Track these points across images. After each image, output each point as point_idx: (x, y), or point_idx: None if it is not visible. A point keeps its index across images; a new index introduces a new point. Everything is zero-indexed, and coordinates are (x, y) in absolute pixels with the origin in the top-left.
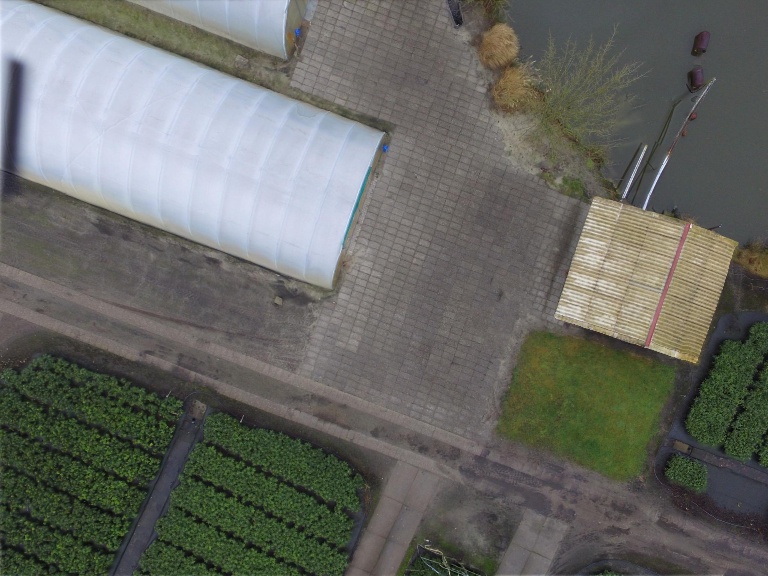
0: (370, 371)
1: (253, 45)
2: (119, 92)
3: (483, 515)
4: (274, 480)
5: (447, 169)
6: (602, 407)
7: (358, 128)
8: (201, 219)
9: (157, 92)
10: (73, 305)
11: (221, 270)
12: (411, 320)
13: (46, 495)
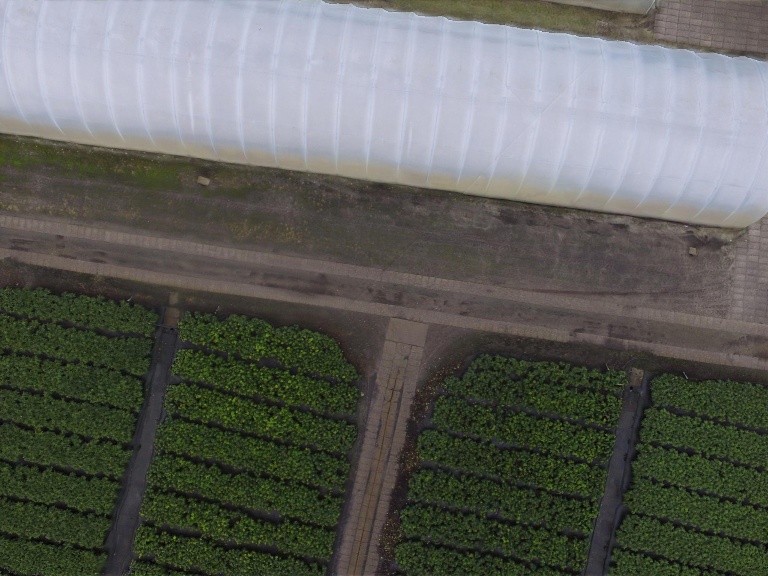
0: None
1: (613, 7)
2: (545, 72)
3: None
4: (733, 428)
5: None
6: None
7: None
8: (632, 182)
9: (579, 64)
10: (494, 301)
11: (629, 234)
12: None
13: (514, 493)
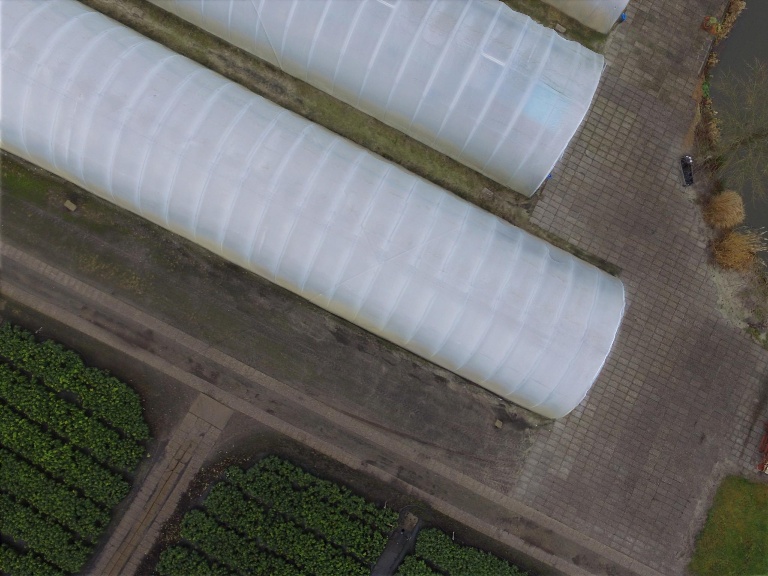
0: (577, 500)
1: (502, 181)
2: (401, 226)
3: None
4: None
5: (664, 315)
6: None
7: (602, 276)
8: (453, 348)
9: (435, 229)
10: (303, 409)
11: (447, 389)
12: (619, 454)
13: None
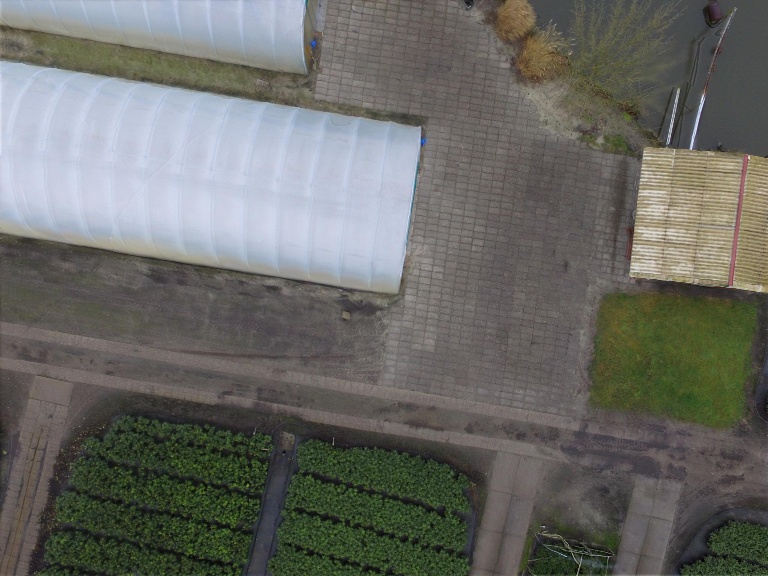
0: (452, 367)
1: (271, 67)
2: (155, 138)
3: (594, 490)
4: (378, 496)
5: (487, 151)
6: (691, 357)
7: (395, 127)
8: (258, 248)
9: (192, 130)
10: (142, 361)
11: (283, 296)
12: (482, 308)
13: (152, 558)
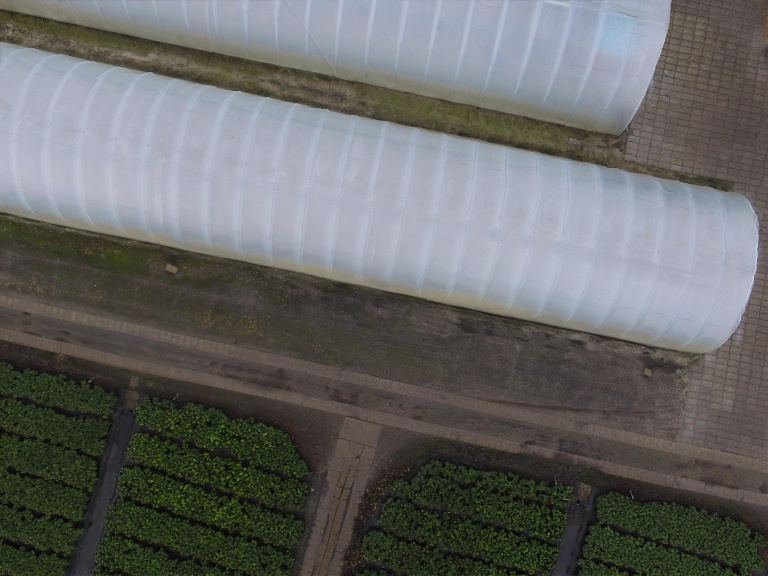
0: (748, 428)
1: (587, 127)
2: (509, 199)
3: None
4: (675, 551)
5: None
6: None
7: (721, 194)
8: (589, 308)
9: (543, 193)
10: (449, 407)
11: (587, 351)
12: None
13: None
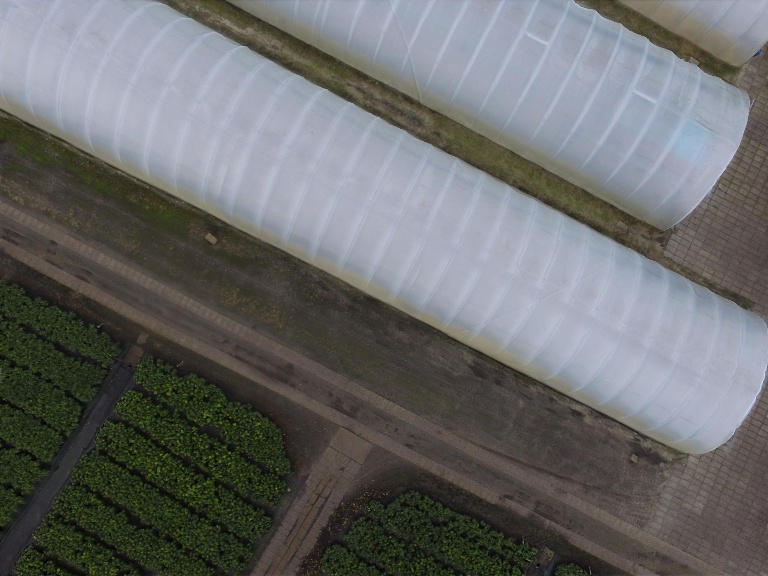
0: (711, 534)
1: (638, 215)
2: (555, 264)
3: None
4: None
5: None
6: None
7: (743, 312)
8: (600, 385)
9: (588, 267)
10: (442, 443)
11: (583, 423)
12: (753, 489)
13: None
